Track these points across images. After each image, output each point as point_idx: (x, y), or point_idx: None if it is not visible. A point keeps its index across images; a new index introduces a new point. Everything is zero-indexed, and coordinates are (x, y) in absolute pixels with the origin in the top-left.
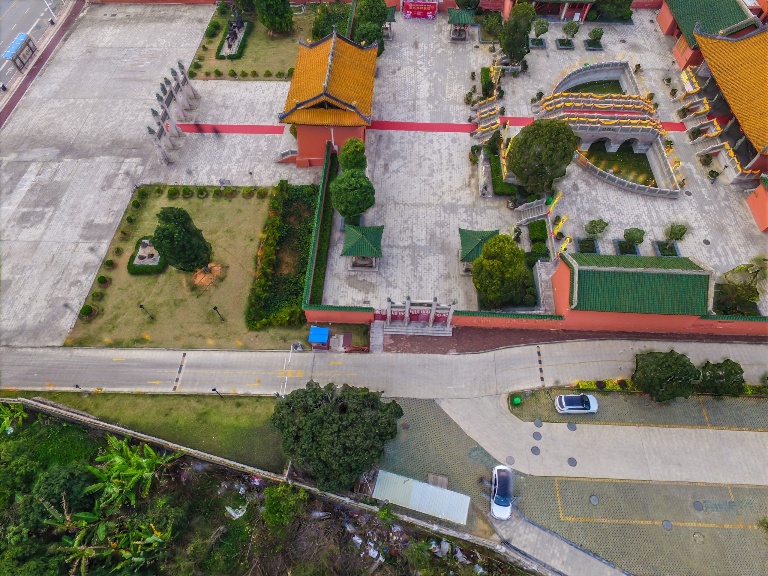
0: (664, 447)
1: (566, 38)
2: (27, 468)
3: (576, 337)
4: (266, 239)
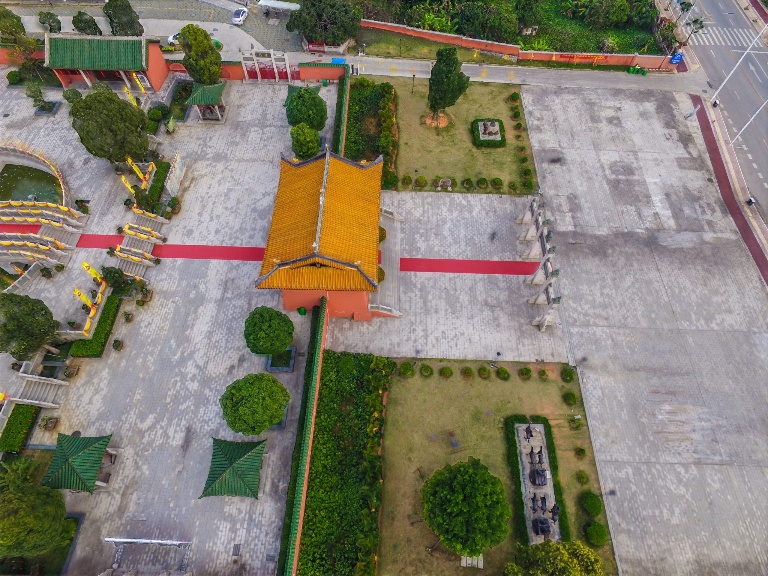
0: None
1: None
2: (491, 20)
3: None
4: None
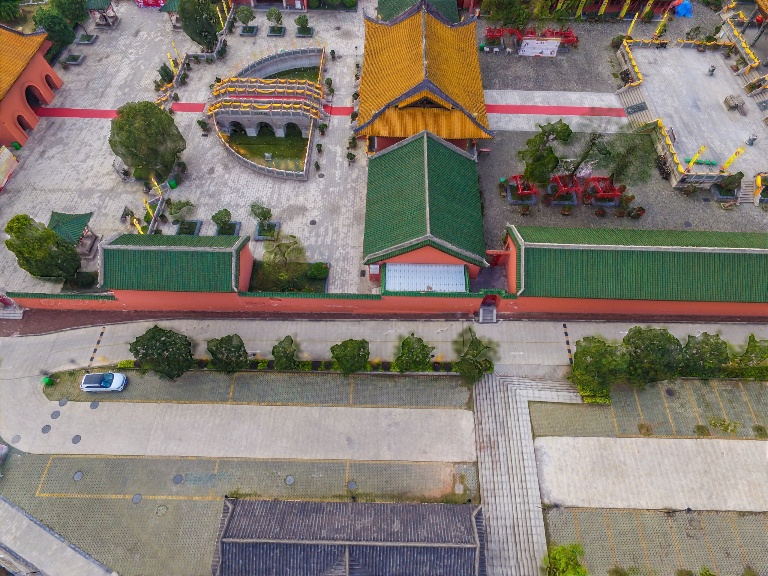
0: (174, 423)
1: (275, 25)
2: None
3: (144, 317)
4: None
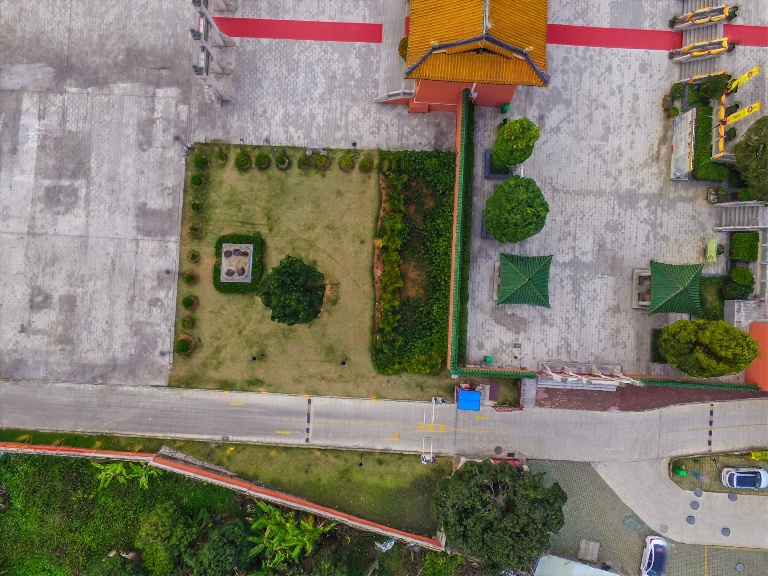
0: None
1: None
2: (188, 539)
3: (759, 395)
4: (383, 246)
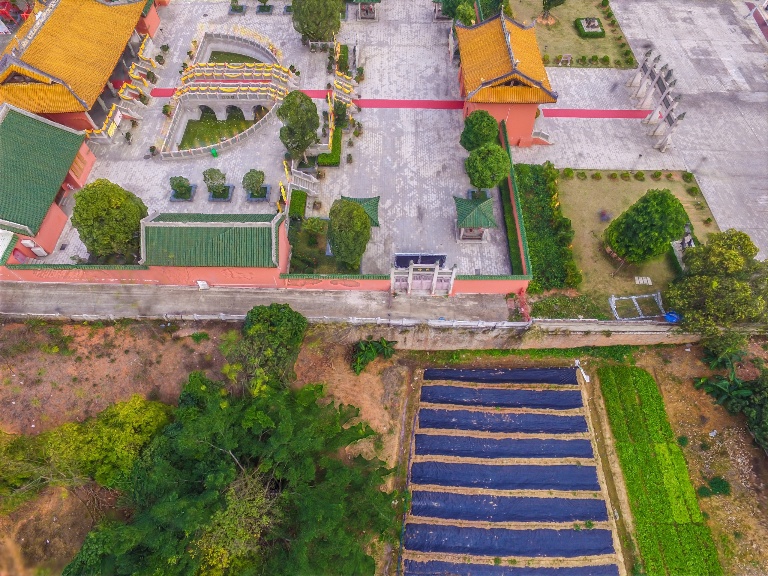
0: None
1: None
2: None
3: None
4: None
